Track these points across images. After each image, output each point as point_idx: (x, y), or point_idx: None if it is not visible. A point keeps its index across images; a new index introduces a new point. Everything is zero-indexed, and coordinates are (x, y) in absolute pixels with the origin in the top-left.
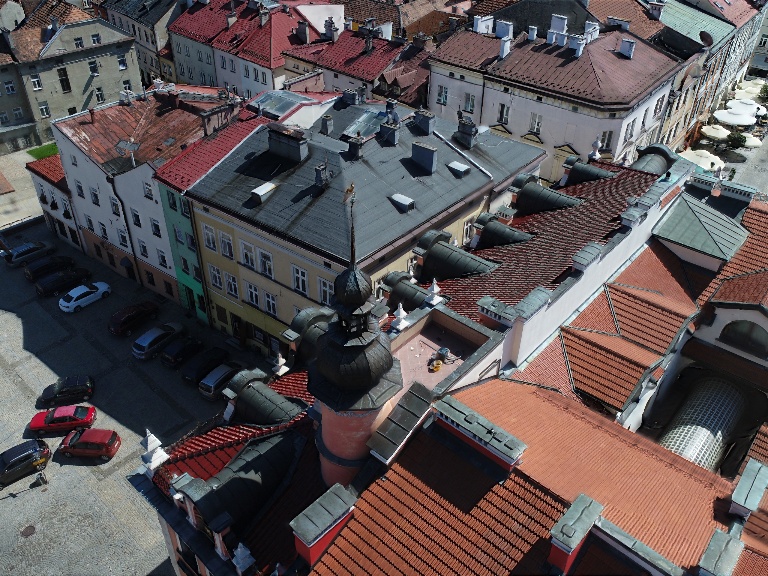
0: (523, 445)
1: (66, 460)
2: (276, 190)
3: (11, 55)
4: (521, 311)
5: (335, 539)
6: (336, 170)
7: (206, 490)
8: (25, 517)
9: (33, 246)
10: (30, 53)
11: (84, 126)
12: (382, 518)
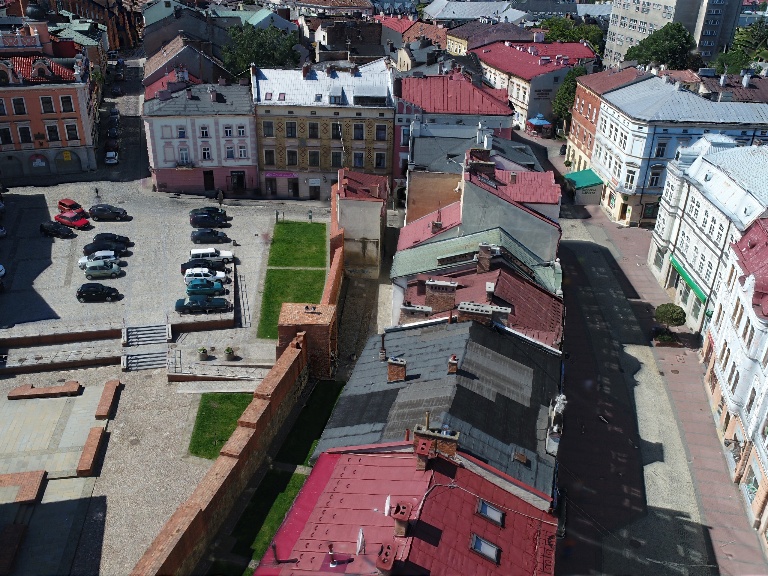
0: None
1: (87, 214)
2: None
3: None
4: None
5: None
6: None
7: None
8: (119, 206)
9: None
10: None
11: None
12: None
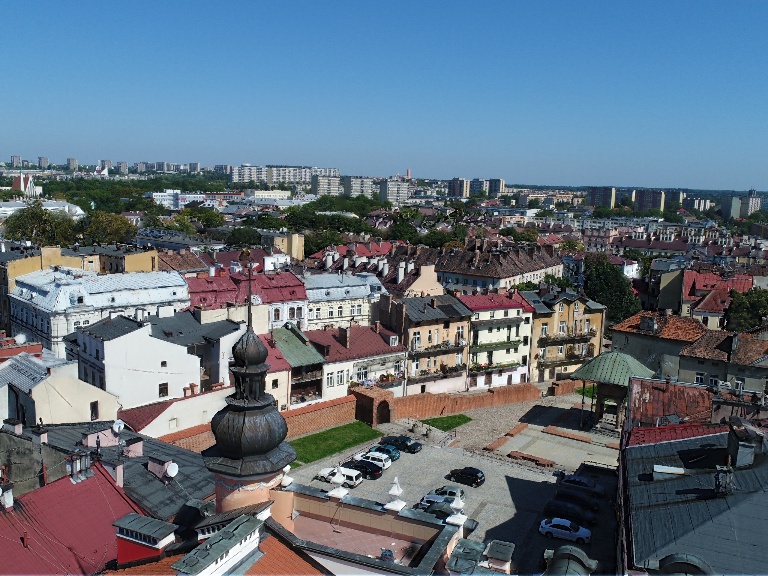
0: (193, 570)
1: None
2: (680, 477)
3: (729, 354)
4: (471, 571)
5: (142, 564)
6: (753, 487)
7: (198, 505)
8: None
9: (585, 481)
10: (746, 358)
11: (655, 390)
12: (155, 571)
